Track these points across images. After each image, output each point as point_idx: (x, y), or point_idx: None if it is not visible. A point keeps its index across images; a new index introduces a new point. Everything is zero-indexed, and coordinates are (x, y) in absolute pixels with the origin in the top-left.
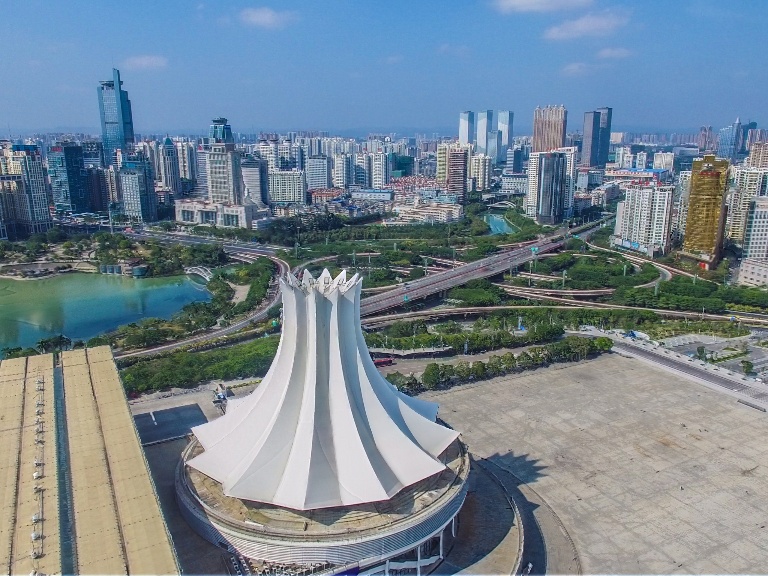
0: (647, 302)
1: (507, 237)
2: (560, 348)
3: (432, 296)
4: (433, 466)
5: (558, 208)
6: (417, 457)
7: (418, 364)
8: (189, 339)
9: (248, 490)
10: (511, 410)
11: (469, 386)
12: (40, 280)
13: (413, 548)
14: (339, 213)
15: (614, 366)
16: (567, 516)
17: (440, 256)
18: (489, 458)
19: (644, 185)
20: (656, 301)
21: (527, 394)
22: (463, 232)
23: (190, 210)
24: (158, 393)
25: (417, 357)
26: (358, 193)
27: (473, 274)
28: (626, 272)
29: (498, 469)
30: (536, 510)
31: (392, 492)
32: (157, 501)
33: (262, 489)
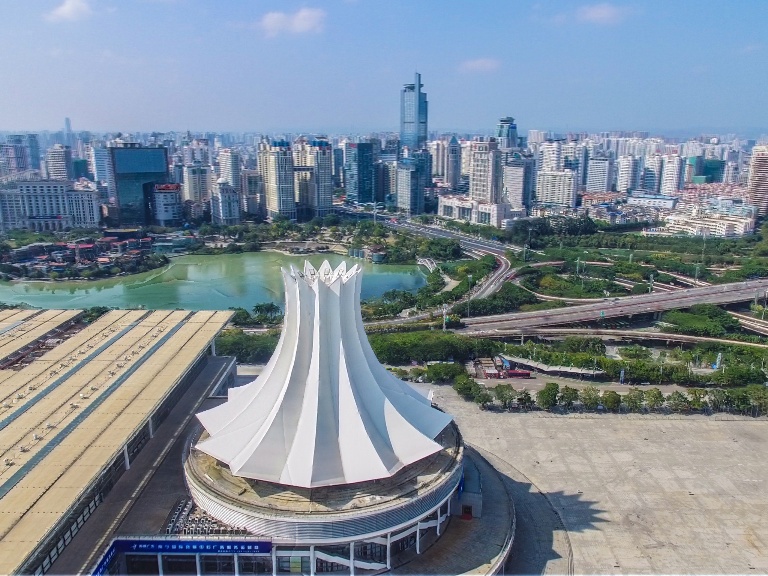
0: None
1: None
2: (734, 396)
3: (644, 316)
4: (380, 471)
5: None
6: (370, 458)
7: (558, 383)
8: (371, 322)
9: (214, 447)
10: (619, 451)
11: (590, 416)
12: (302, 257)
13: (333, 543)
14: (600, 218)
15: None
16: None
17: (688, 274)
18: (548, 493)
19: None
20: None
21: (654, 439)
22: (743, 250)
23: (450, 205)
24: None
25: (563, 375)
26: (635, 198)
27: (707, 298)
28: None
29: (547, 507)
30: (552, 560)
31: (321, 483)
32: (130, 435)
33: (227, 450)
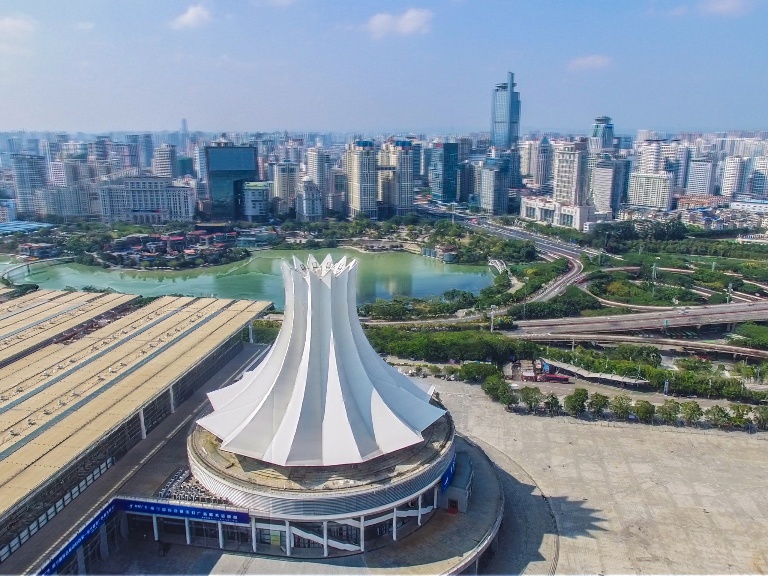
0: None
1: None
2: None
3: (716, 327)
4: (354, 456)
5: None
6: (348, 444)
7: (597, 390)
8: (425, 320)
9: (213, 424)
10: (639, 462)
11: (619, 425)
12: (376, 254)
13: (305, 520)
14: (693, 223)
15: None
16: None
17: None
18: (550, 497)
19: None
20: None
21: (682, 453)
22: None
23: (533, 207)
24: None
25: (603, 383)
26: (739, 203)
27: None
28: None
29: (545, 510)
30: (535, 562)
31: (296, 463)
32: (138, 406)
33: (224, 427)
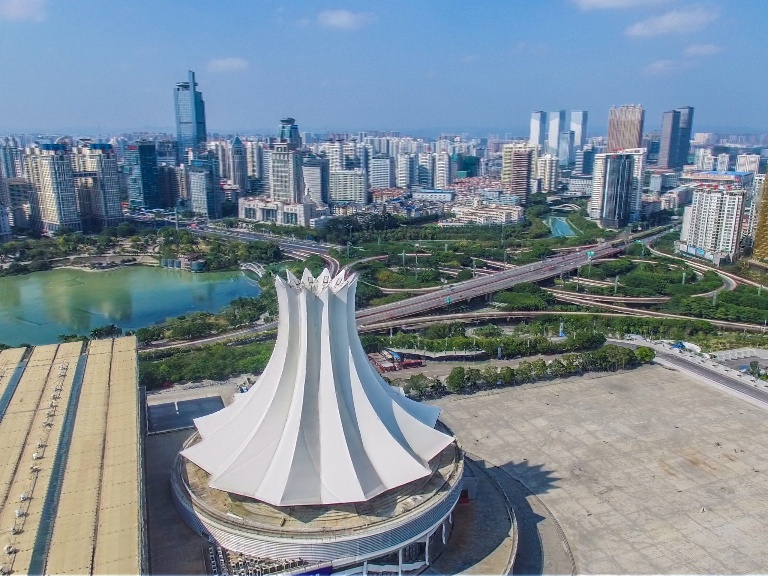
0: (704, 312)
1: (565, 240)
2: (596, 357)
3: (477, 299)
4: (418, 470)
5: (623, 211)
6: (403, 460)
7: (448, 367)
8: (231, 333)
9: (231, 483)
10: (534, 418)
11: (495, 391)
12: (107, 272)
13: (391, 552)
14: (397, 213)
15: (653, 378)
16: (572, 531)
17: (493, 258)
18: (502, 466)
19: (712, 189)
20: (714, 311)
21: (554, 403)
22: (521, 234)
23: (252, 208)
24: (190, 384)
25: (448, 360)
26: (419, 193)
27: (522, 277)
28: (686, 280)
29: (509, 478)
30: (540, 522)
31: (371, 494)
32: (138, 488)
33: (246, 483)
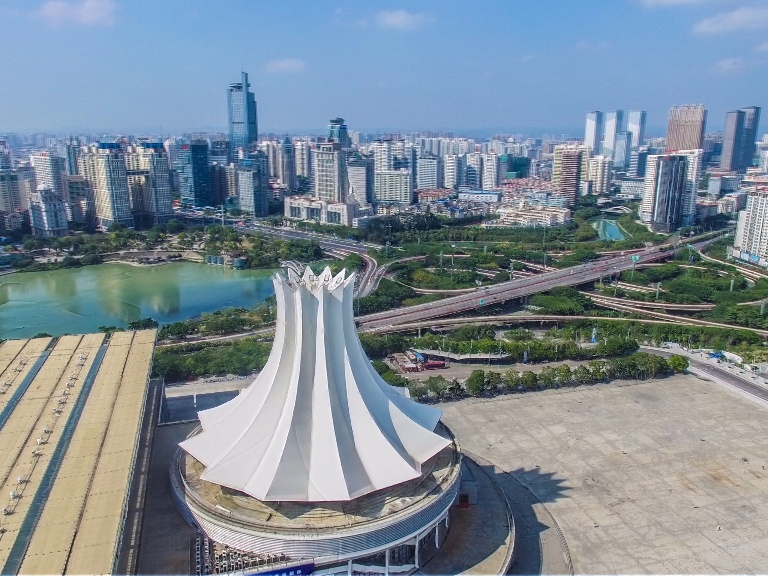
0: (750, 321)
1: (612, 244)
2: (625, 364)
3: (513, 301)
4: (408, 472)
5: (675, 215)
6: (394, 461)
7: (472, 369)
8: (263, 329)
9: (222, 476)
10: (552, 425)
11: (515, 396)
12: (153, 267)
13: (375, 552)
14: (441, 214)
15: (685, 388)
16: (576, 542)
17: (533, 261)
18: (512, 472)
19: None
20: (761, 321)
21: (576, 410)
22: (566, 237)
23: (297, 206)
24: (214, 378)
25: (473, 362)
26: (465, 194)
27: (560, 281)
28: (736, 287)
29: (517, 484)
30: (544, 532)
31: (357, 493)
32: (129, 476)
33: (236, 476)
